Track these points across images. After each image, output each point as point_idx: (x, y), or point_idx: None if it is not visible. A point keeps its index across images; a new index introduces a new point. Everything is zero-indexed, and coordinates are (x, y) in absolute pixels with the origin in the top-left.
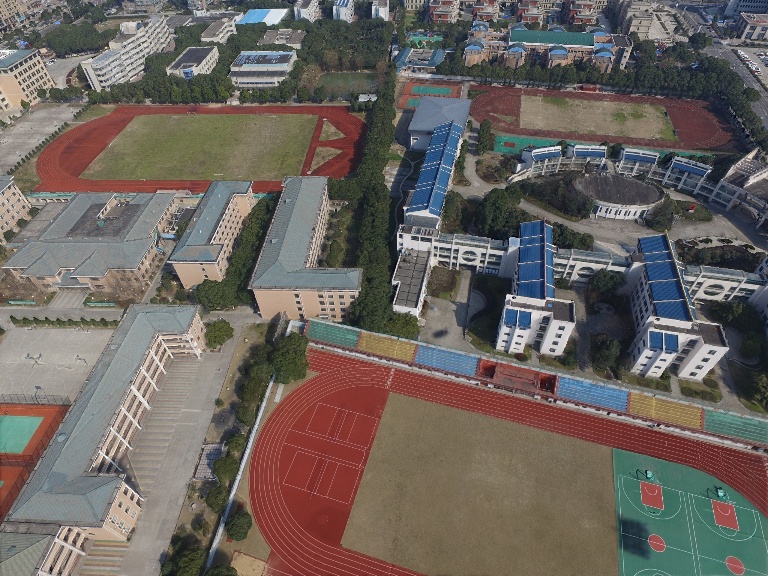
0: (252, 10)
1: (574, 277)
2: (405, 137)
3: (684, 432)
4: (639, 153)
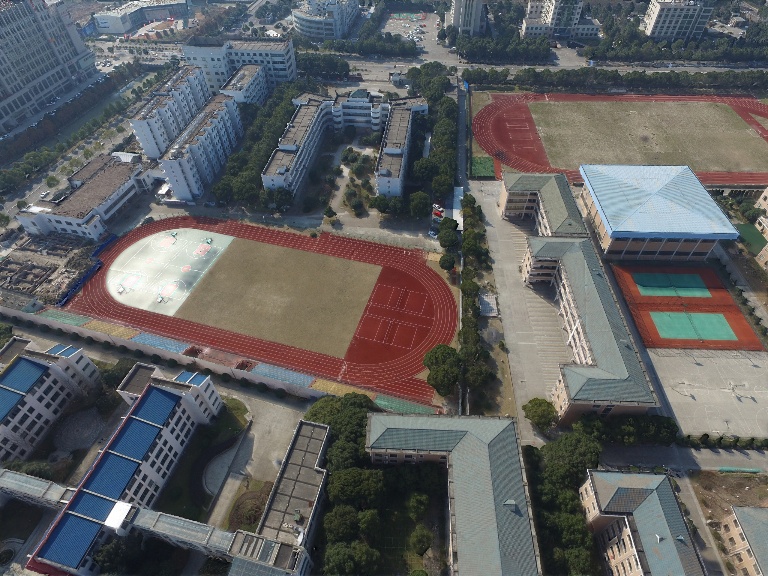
0: None
1: None
2: None
3: None
4: None
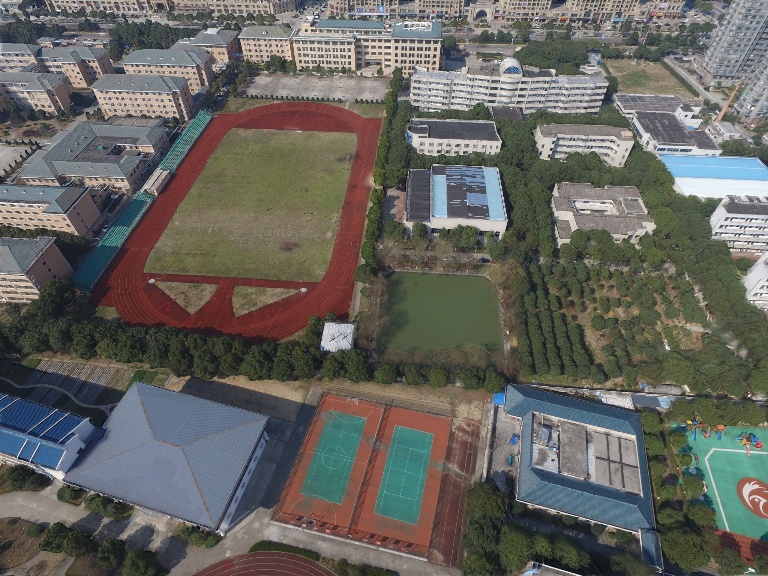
0: (758, 161)
1: None
2: None
3: None
4: None
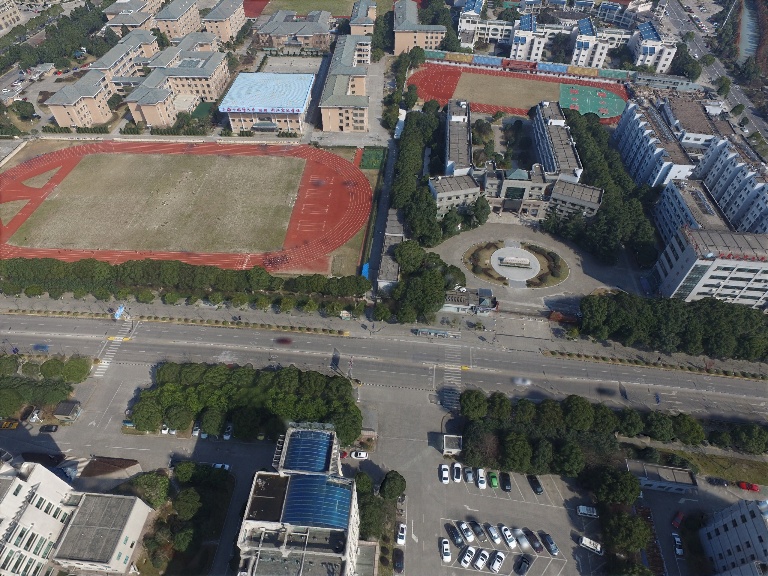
0: None
1: (546, 40)
2: (449, 2)
3: (590, 80)
4: (584, 1)
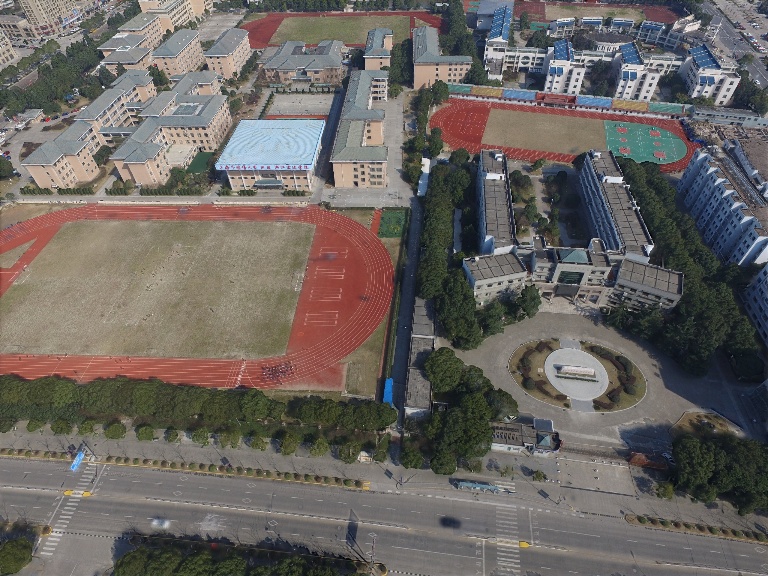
0: None
1: None
2: (471, 24)
3: (639, 115)
4: (622, 20)
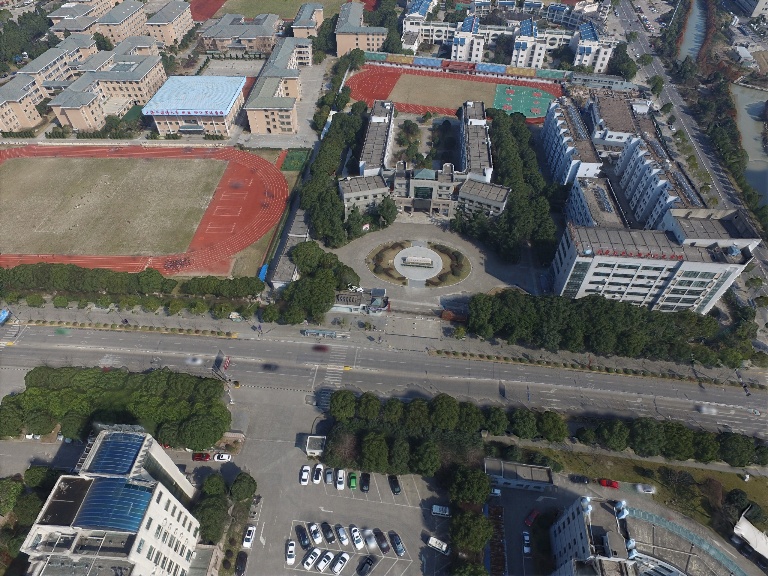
0: None
1: (490, 41)
2: (403, 4)
3: (528, 80)
4: (533, 2)
